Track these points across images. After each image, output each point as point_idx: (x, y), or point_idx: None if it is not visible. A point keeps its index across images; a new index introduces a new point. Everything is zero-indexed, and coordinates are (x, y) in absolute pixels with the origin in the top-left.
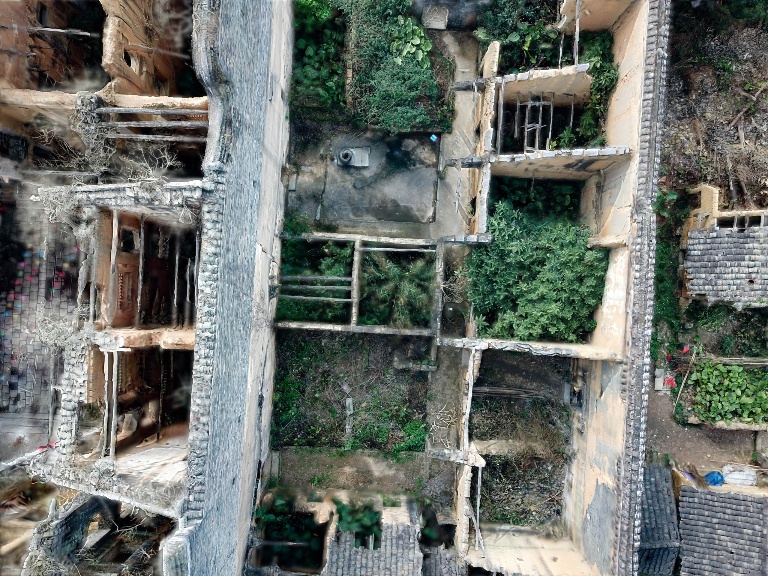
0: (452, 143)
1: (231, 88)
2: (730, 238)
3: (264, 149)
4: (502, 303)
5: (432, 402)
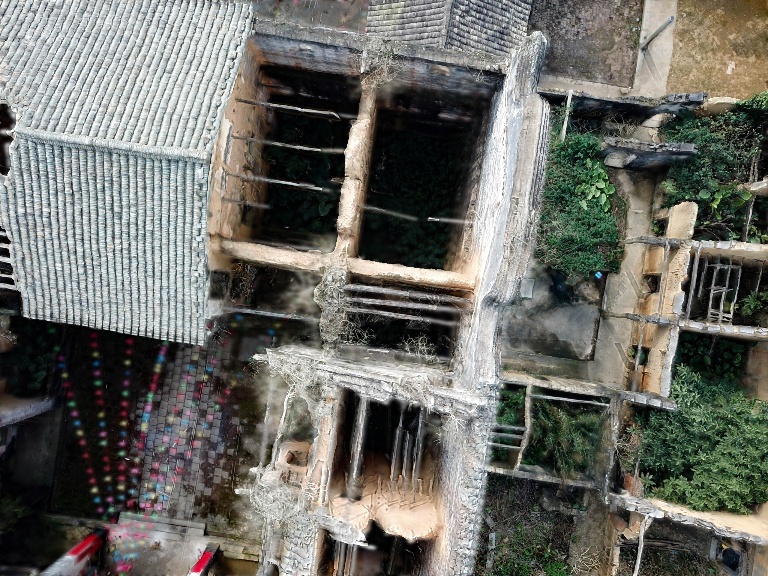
0: (619, 283)
1: None
2: None
3: None
4: (673, 466)
5: (575, 544)
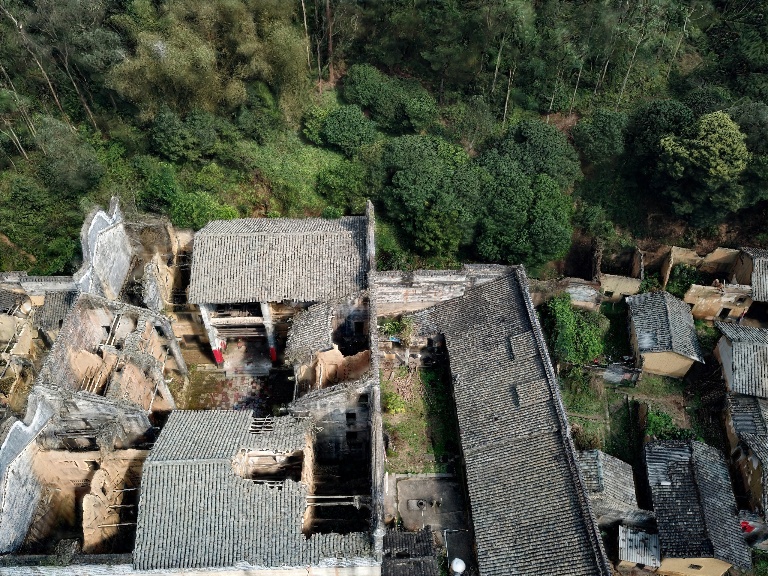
0: None
1: None
2: None
3: None
4: None
5: None
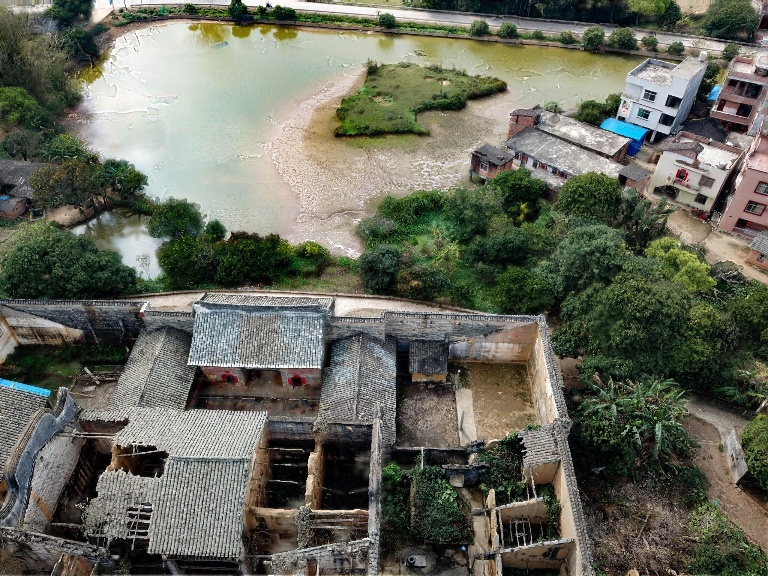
0: (475, 551)
1: None
2: None
3: None
4: None
5: None
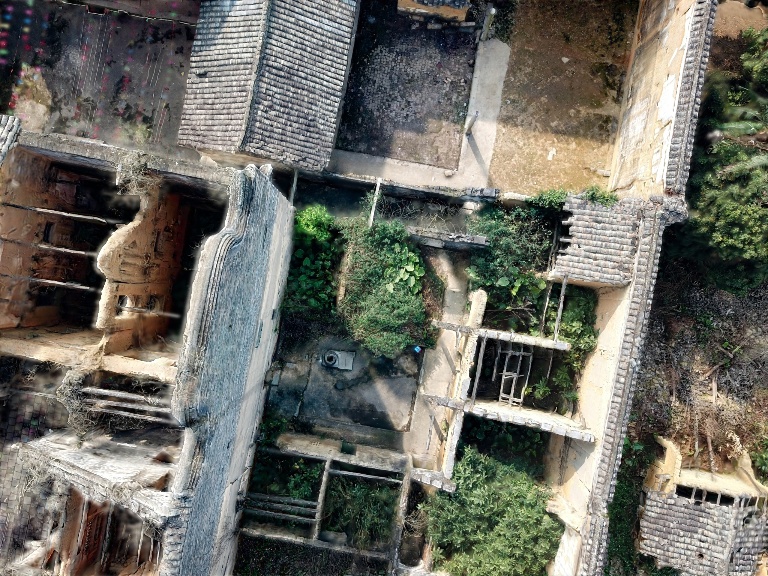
0: (435, 359)
1: (210, 408)
2: (686, 509)
3: (245, 397)
4: None
5: None
